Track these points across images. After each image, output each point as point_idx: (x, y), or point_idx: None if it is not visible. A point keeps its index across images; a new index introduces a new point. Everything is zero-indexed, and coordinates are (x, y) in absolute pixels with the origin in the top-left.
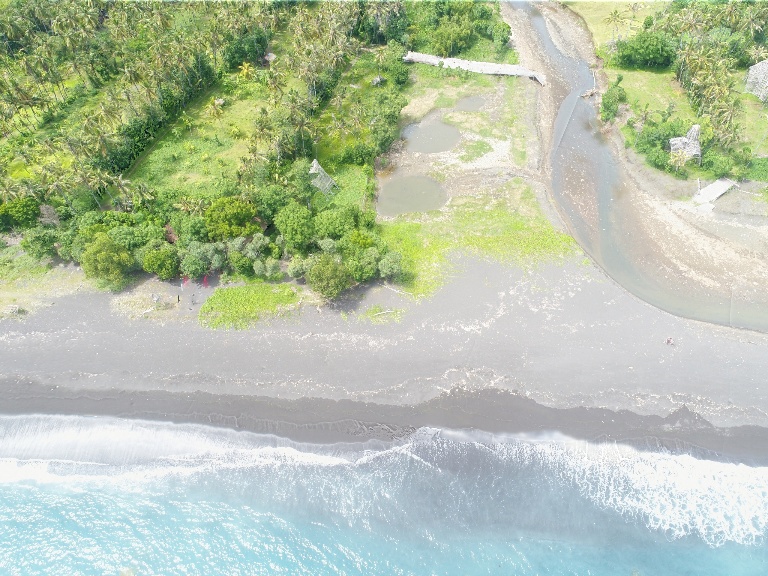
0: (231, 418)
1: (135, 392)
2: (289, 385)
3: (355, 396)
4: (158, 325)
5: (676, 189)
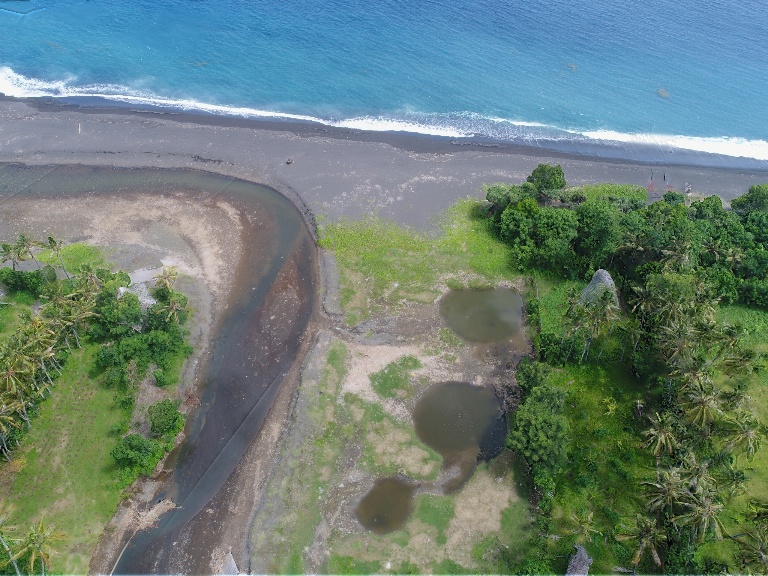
0: (585, 154)
1: (660, 166)
2: (554, 161)
3: None
4: (674, 188)
5: (183, 279)
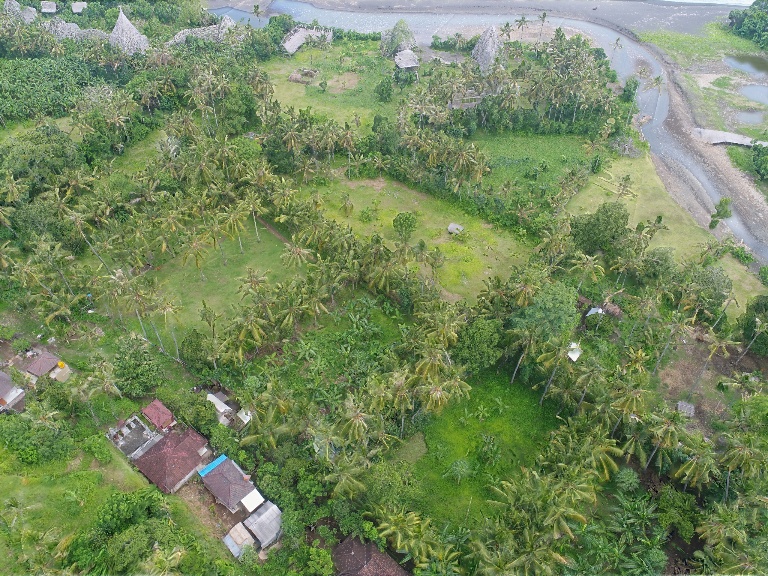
0: None
1: None
2: None
3: (719, 6)
4: None
5: None
